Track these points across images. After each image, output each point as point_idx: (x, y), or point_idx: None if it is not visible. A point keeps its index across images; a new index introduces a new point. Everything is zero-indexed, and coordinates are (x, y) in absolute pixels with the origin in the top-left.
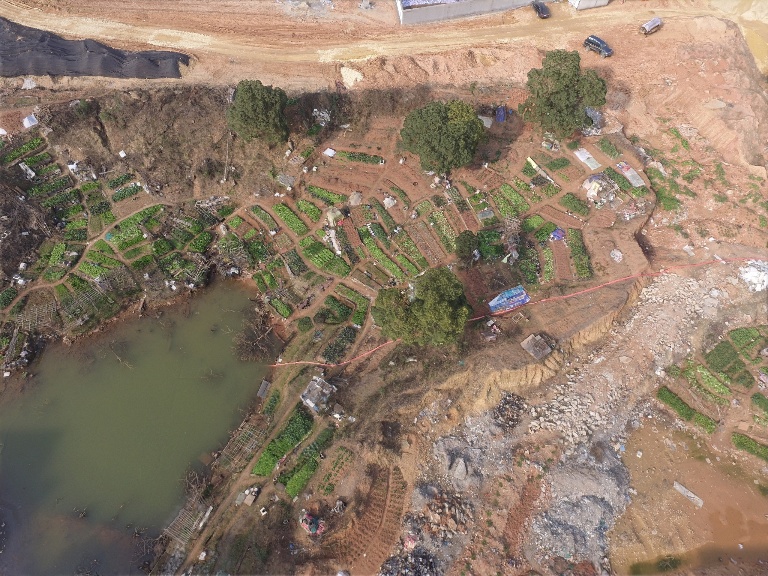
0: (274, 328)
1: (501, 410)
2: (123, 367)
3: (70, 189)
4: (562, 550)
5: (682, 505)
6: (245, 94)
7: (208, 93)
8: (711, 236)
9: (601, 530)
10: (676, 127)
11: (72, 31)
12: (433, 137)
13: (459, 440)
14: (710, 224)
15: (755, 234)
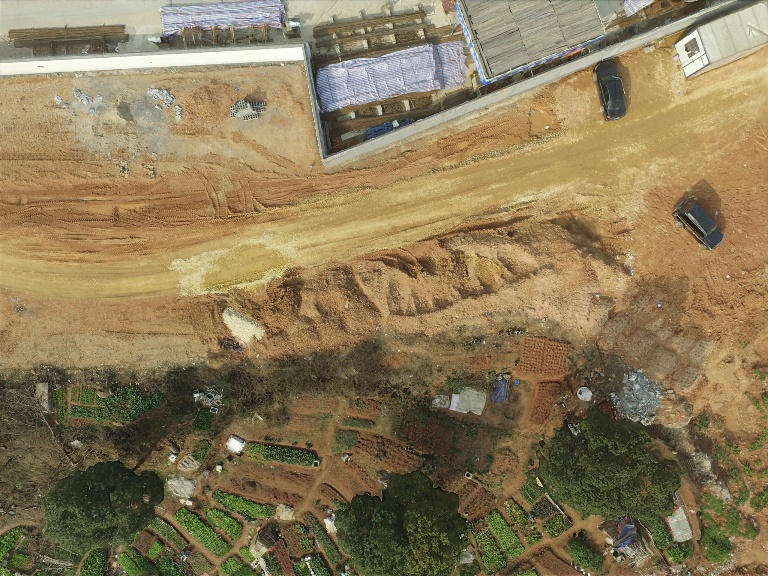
0: None
1: None
2: None
3: None
4: None
5: None
6: None
7: (4, 406)
8: None
9: None
10: None
11: None
12: None
13: None
14: None
15: None
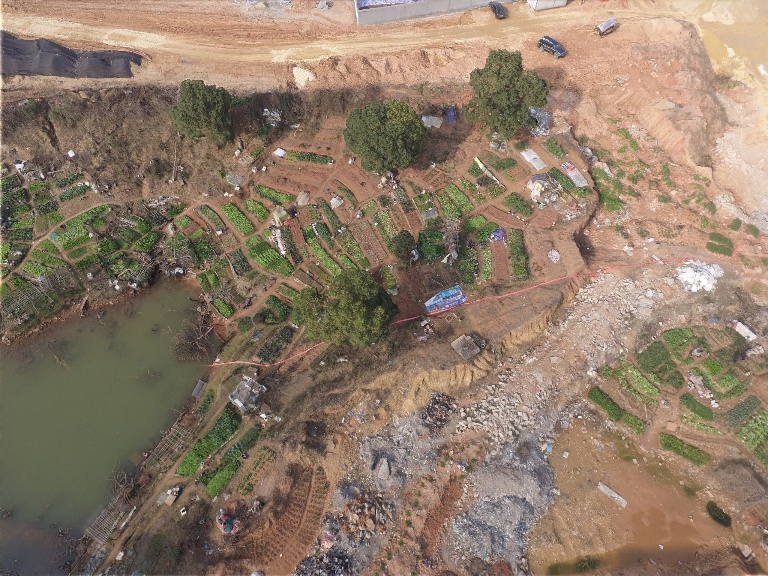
0: (215, 328)
1: (430, 410)
2: (60, 367)
3: (17, 188)
4: (479, 550)
5: (605, 506)
6: (186, 94)
7: (157, 93)
8: (651, 236)
9: (521, 530)
10: (626, 128)
11: (27, 31)
12: (371, 137)
13: (385, 440)
14: (651, 224)
15: (695, 235)
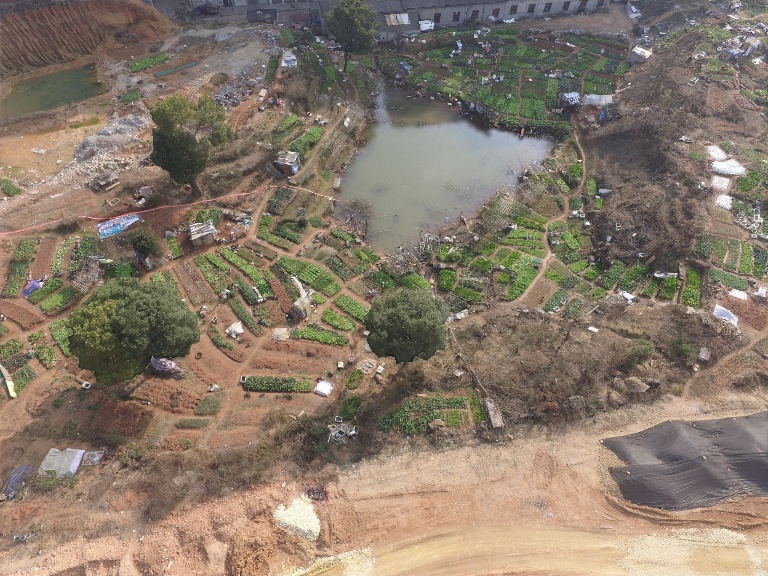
0: None
1: None
2: None
3: None
4: None
5: None
6: None
7: (526, 400)
8: None
9: None
10: None
11: None
12: None
13: None
14: None
15: None
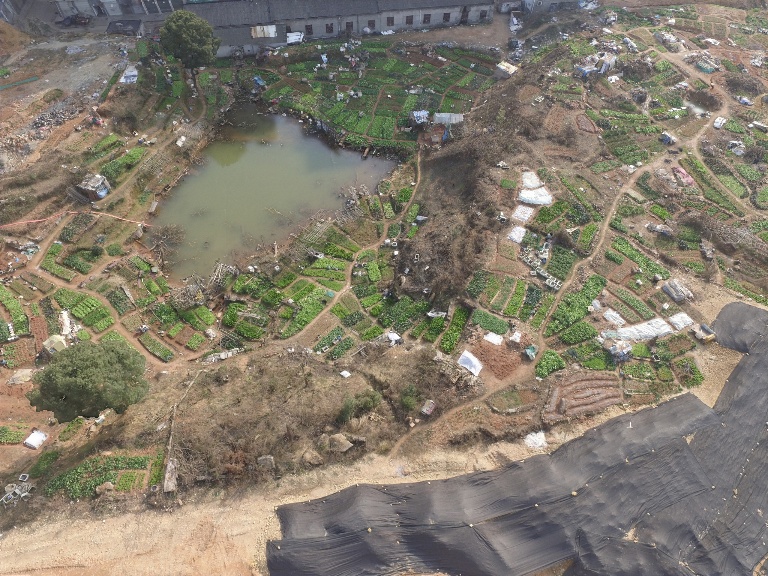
0: None
1: None
2: None
3: None
4: None
5: None
6: None
7: (208, 461)
8: None
9: None
10: None
11: None
12: None
13: None
14: None
15: None
